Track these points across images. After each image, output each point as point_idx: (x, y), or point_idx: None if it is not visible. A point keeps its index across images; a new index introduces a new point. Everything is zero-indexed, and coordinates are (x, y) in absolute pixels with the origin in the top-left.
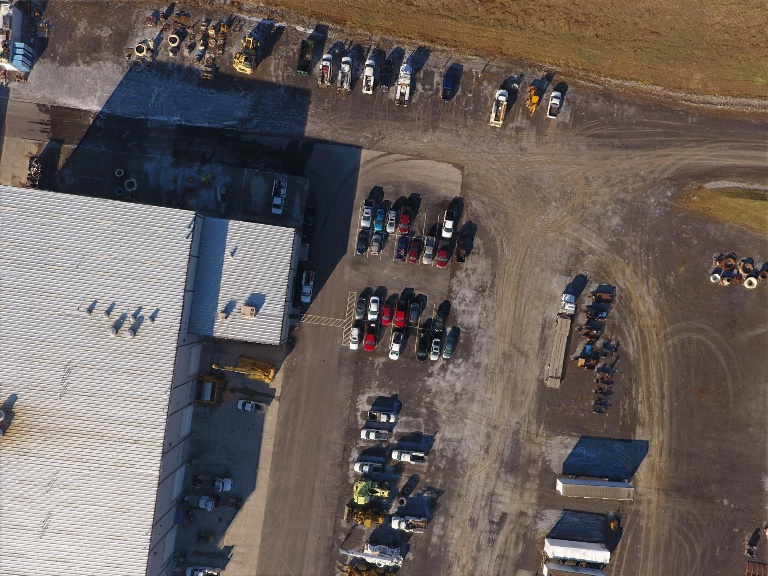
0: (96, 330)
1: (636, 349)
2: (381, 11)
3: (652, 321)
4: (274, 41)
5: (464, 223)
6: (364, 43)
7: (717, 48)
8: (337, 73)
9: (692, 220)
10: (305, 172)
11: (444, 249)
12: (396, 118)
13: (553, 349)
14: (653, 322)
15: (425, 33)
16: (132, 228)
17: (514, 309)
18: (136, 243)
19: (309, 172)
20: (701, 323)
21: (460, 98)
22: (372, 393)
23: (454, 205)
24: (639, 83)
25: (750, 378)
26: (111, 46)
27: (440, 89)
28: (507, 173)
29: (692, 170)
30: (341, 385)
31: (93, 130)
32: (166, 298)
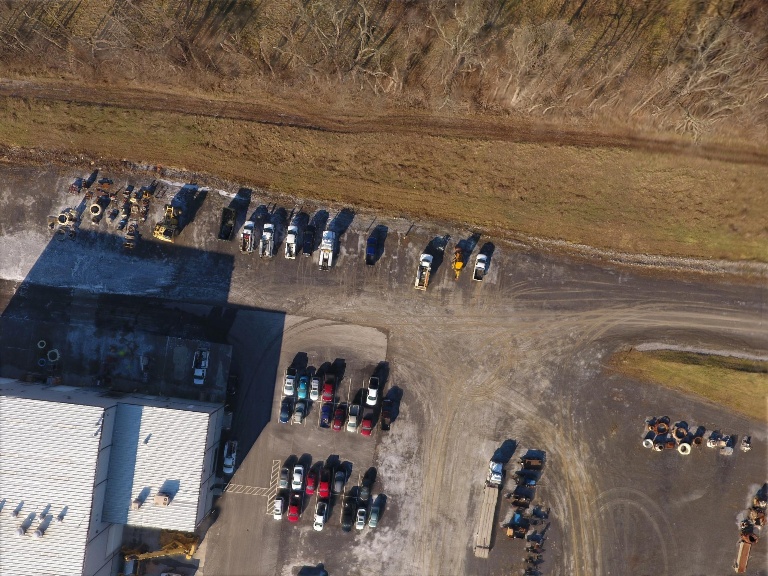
0: (5, 530)
1: (567, 516)
2: (303, 175)
3: (583, 487)
4: (197, 207)
5: (390, 388)
6: (287, 206)
7: (645, 211)
8: (260, 238)
9: (623, 383)
10: (228, 339)
11: (368, 418)
12: (320, 282)
13: (481, 518)
14: (584, 488)
15: (349, 196)
16: (40, 426)
17: (441, 475)
18: (45, 441)
19: (232, 339)
20: (634, 489)
21: (385, 261)
22: (297, 563)
23: (379, 370)
24: (567, 242)
25: (686, 546)
26: (34, 215)
27: (364, 252)
28: (433, 336)
29: (623, 332)
30: (266, 555)
31: (16, 300)
32: (75, 496)
